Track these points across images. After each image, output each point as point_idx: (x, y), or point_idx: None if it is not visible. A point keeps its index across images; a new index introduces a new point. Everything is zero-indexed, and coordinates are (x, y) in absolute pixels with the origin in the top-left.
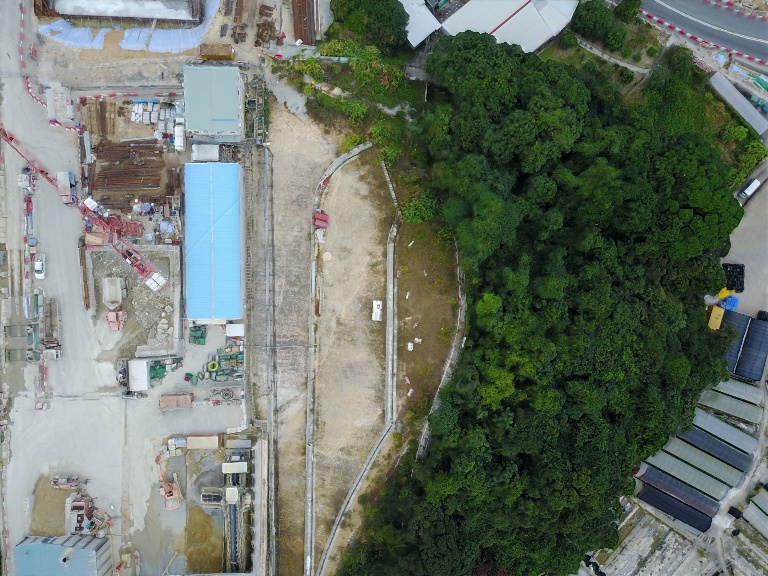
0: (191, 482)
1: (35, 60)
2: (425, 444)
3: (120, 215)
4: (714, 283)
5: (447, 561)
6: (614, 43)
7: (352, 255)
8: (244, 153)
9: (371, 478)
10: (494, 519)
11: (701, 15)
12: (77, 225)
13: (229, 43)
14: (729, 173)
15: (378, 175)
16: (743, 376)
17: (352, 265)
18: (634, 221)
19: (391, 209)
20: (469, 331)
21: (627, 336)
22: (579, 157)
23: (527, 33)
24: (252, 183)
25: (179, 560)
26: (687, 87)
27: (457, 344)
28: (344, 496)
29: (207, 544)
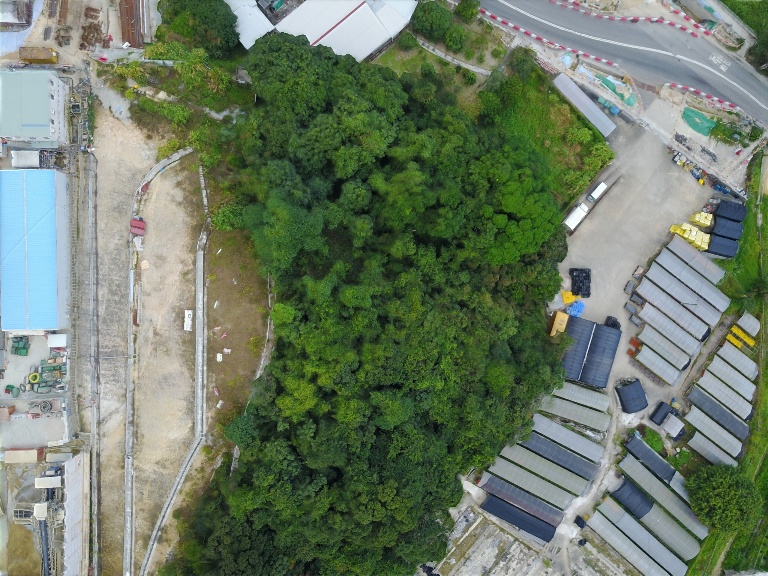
0: (12, 497)
1: None
2: None
3: None
4: (547, 289)
5: None
6: (452, 44)
7: (167, 263)
8: (70, 159)
9: (185, 492)
10: (305, 533)
11: (547, 16)
12: None
13: (53, 46)
14: (550, 177)
15: (193, 181)
16: (587, 383)
17: (167, 274)
18: (440, 227)
19: (200, 216)
20: (277, 341)
21: (447, 344)
22: (396, 162)
23: (363, 35)
24: (78, 190)
25: None
26: (531, 89)
27: (268, 354)
28: (159, 511)
29: (29, 560)
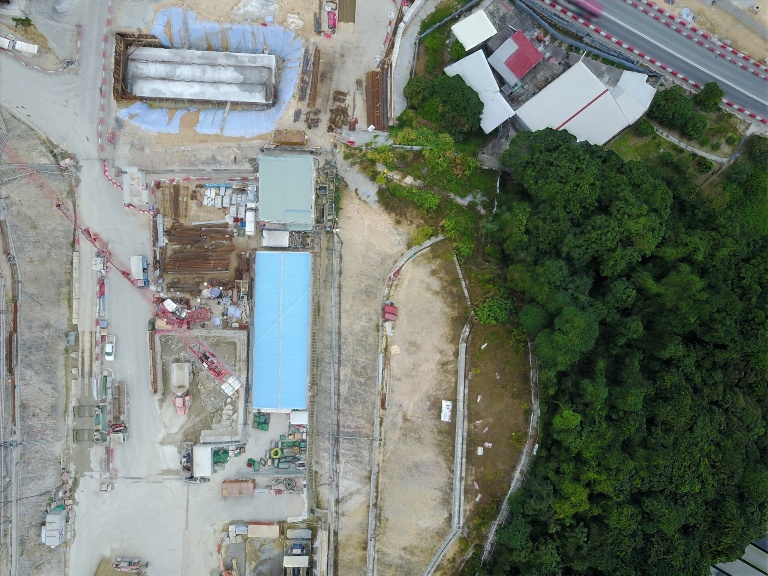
0: (250, 569)
1: (112, 143)
2: (491, 549)
3: (189, 298)
4: None
5: None
6: (693, 134)
7: (422, 351)
8: (313, 238)
9: None
10: None
11: None
12: (147, 307)
13: (302, 128)
14: None
15: (450, 271)
16: None
17: (421, 361)
18: (719, 334)
19: (464, 309)
20: (542, 438)
21: (705, 447)
22: (659, 260)
23: (603, 122)
24: (320, 268)
25: None
26: (767, 178)
27: (528, 450)
28: None
29: None
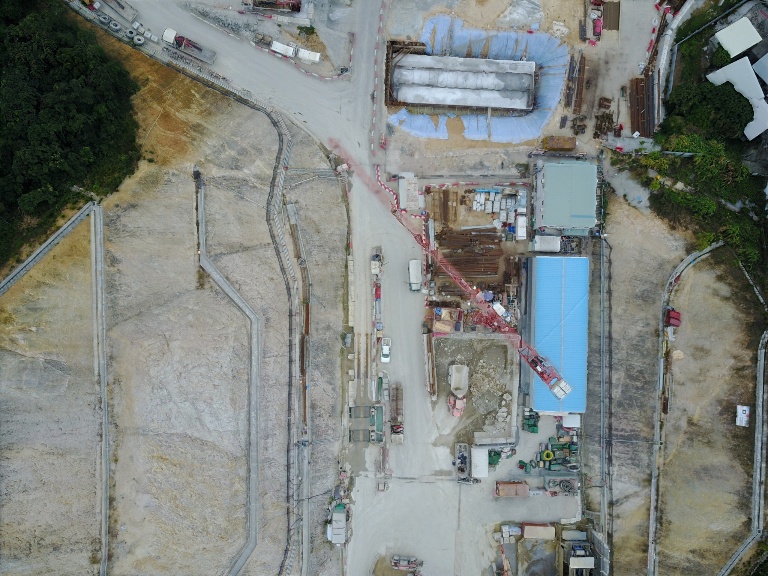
0: (522, 570)
1: (385, 149)
2: None
3: (460, 302)
4: None
5: None
6: None
7: (710, 356)
8: (578, 243)
9: None
10: None
11: None
12: (419, 310)
13: (568, 134)
14: None
15: (740, 277)
16: None
17: (710, 366)
18: None
19: (763, 315)
20: None
21: None
22: None
23: None
24: None
25: None
26: None
27: None
28: None
29: None
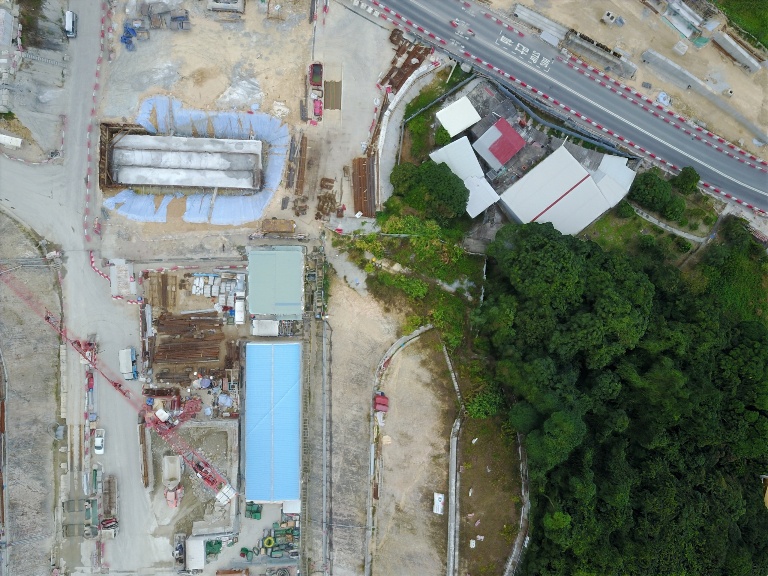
0: None
1: (99, 234)
2: None
3: (179, 388)
4: None
5: None
6: (672, 217)
7: (413, 443)
8: (302, 324)
9: None
10: None
11: (757, 183)
12: (136, 399)
13: (290, 215)
14: None
15: (440, 363)
16: None
17: (413, 453)
18: (701, 429)
19: (455, 403)
20: (532, 531)
21: (689, 532)
22: (642, 351)
23: (585, 206)
24: (310, 355)
25: None
26: (743, 257)
27: (519, 542)
28: None
29: None
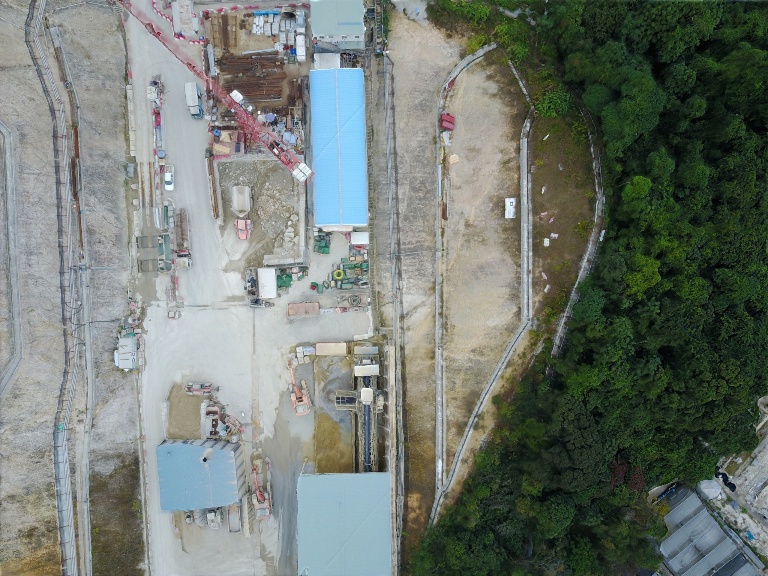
0: (319, 389)
1: None
2: (560, 343)
3: None
4: None
5: (594, 452)
6: None
7: (481, 155)
8: (363, 63)
9: (505, 378)
10: (636, 415)
11: None
12: (203, 137)
13: None
14: None
15: (506, 73)
16: None
17: (481, 165)
18: None
19: (524, 104)
20: (608, 224)
21: None
22: (716, 46)
23: None
24: (371, 93)
25: (309, 466)
26: None
27: (594, 239)
28: (477, 397)
29: (336, 450)
